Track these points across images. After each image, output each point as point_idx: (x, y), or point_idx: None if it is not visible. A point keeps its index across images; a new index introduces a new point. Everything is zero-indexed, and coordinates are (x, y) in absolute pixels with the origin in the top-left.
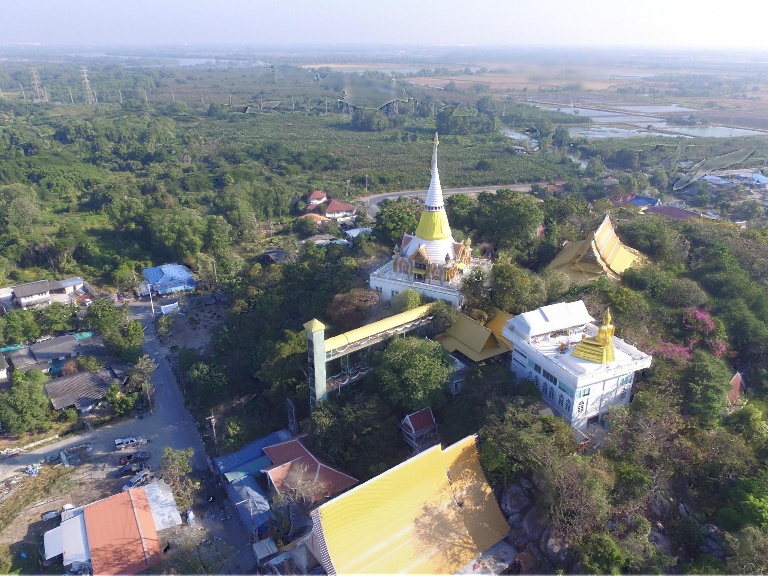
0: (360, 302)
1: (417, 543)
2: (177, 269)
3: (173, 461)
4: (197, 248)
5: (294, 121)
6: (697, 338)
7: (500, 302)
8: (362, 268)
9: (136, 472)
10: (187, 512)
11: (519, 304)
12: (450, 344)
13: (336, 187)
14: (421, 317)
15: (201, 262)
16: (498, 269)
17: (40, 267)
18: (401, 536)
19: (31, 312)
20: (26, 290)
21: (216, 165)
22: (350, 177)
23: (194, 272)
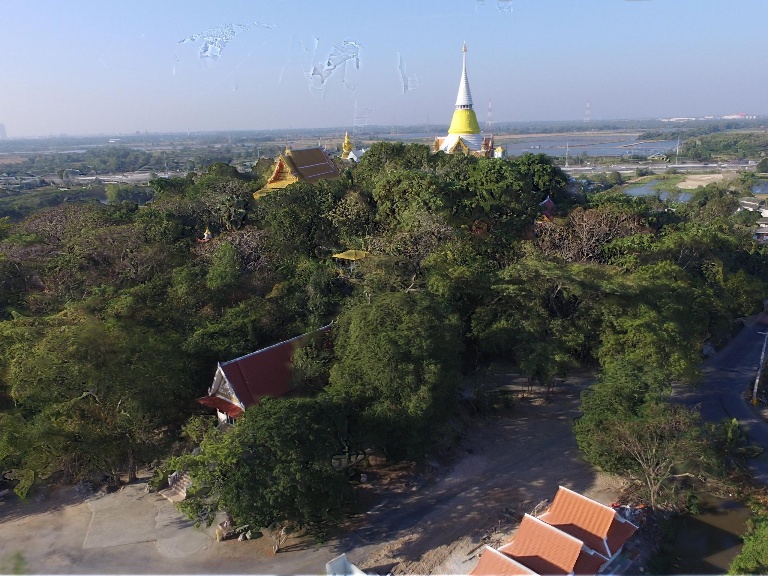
0: None
1: None
2: None
3: None
4: None
5: None
6: None
7: None
8: None
9: None
10: None
11: None
12: None
13: None
14: None
15: None
16: None
17: None
18: None
19: None
20: None
21: None
22: None
23: None
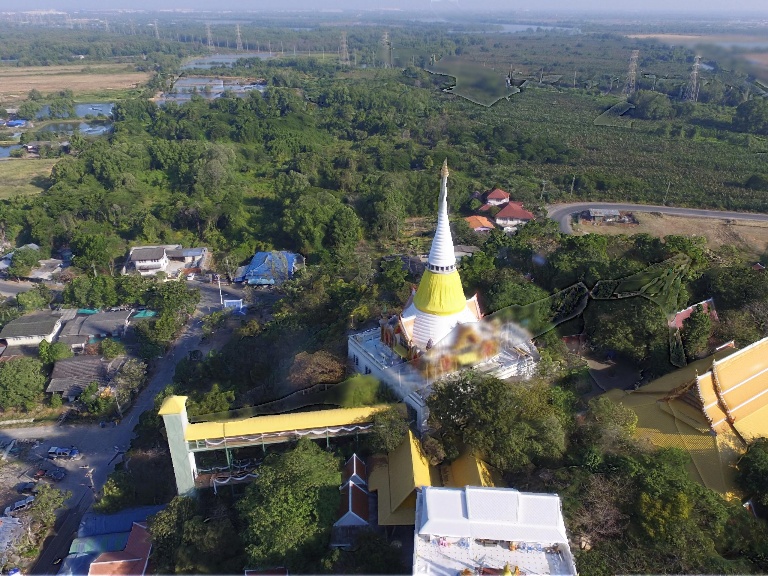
0: (315, 372)
1: None
2: (287, 258)
3: (39, 503)
4: (316, 239)
5: (561, 100)
6: None
7: (468, 439)
8: (376, 319)
9: (35, 493)
10: (9, 572)
11: (495, 452)
12: (378, 476)
13: (526, 188)
14: (358, 422)
15: (274, 261)
16: (482, 386)
17: (191, 230)
18: None
19: (114, 280)
20: (142, 254)
21: (436, 143)
22: (564, 176)
23: (306, 264)
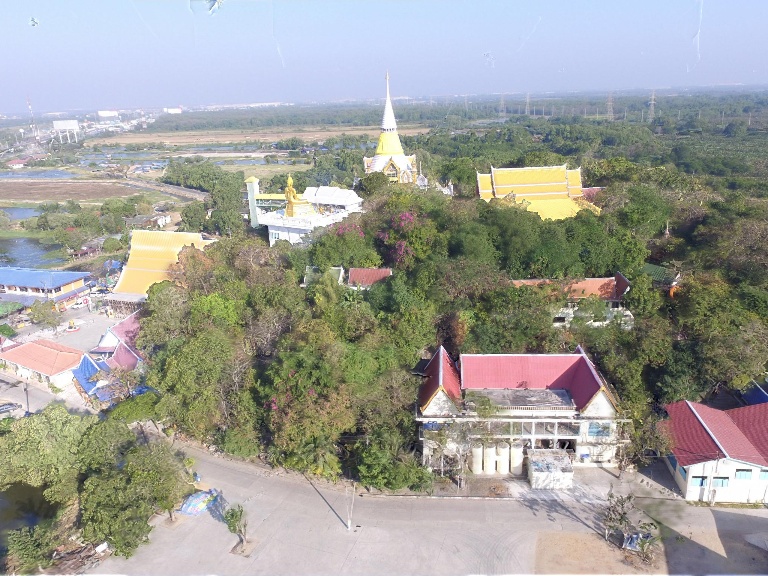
0: None
1: (165, 275)
2: None
3: None
4: None
5: None
6: (393, 235)
7: None
8: None
9: None
10: None
11: None
12: None
13: None
14: None
15: None
16: (372, 173)
17: None
18: (160, 267)
19: None
20: None
21: None
22: None
23: None
